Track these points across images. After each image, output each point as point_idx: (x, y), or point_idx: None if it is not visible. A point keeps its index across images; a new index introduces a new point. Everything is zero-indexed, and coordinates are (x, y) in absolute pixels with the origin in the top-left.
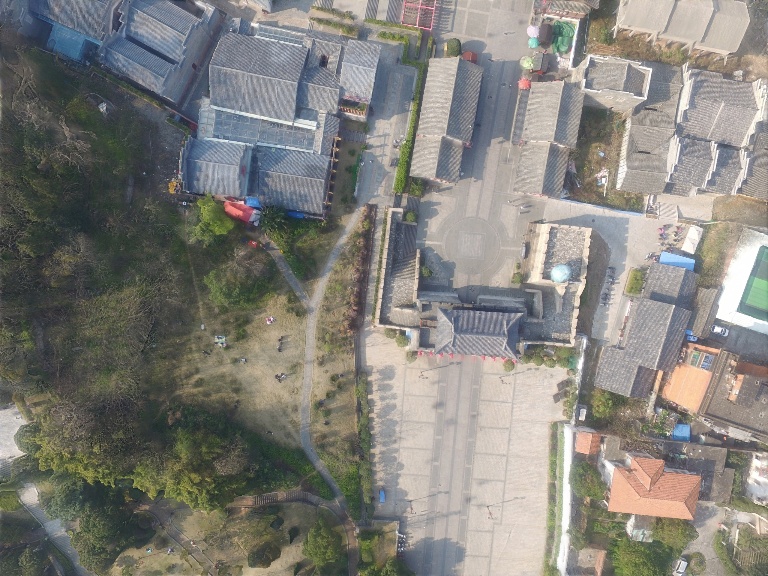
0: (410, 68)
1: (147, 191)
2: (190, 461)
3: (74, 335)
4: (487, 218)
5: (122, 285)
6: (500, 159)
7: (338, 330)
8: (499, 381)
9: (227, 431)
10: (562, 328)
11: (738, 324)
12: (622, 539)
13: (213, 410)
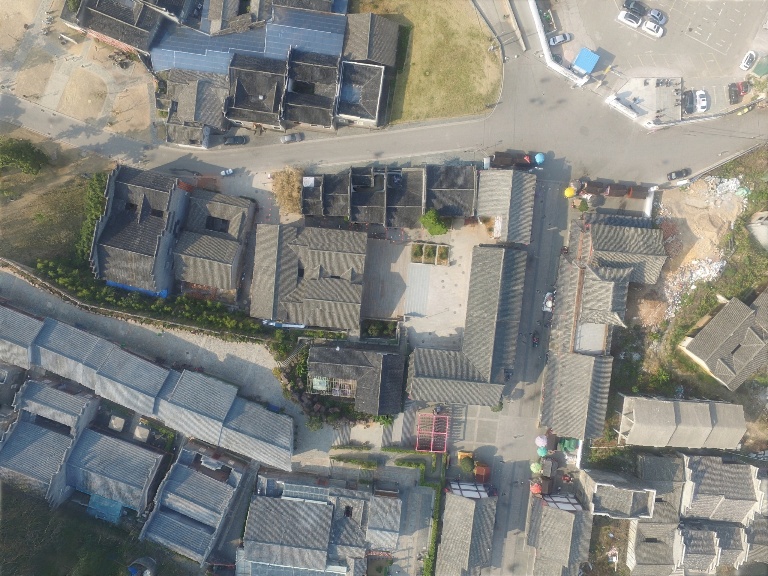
0: (428, 488)
1: None
2: None
3: None
4: None
5: None
6: (516, 548)
7: None
8: None
9: None
10: None
11: None
12: None
13: None
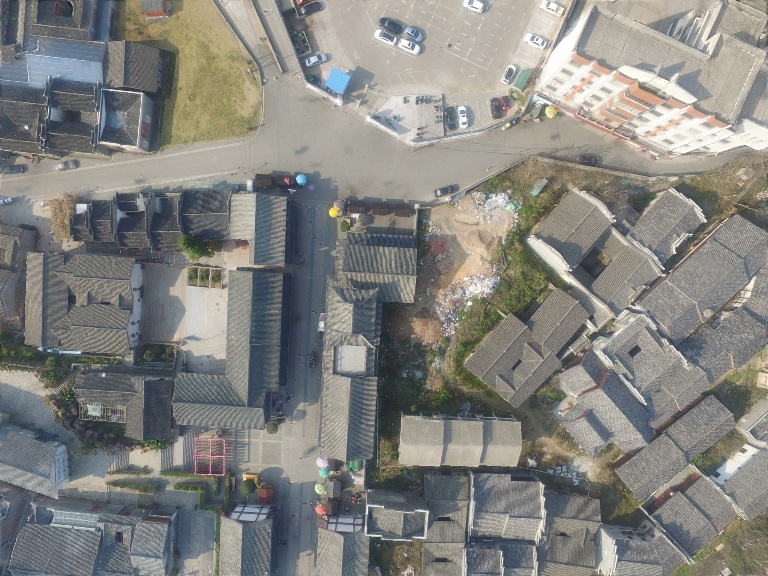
0: (209, 511)
1: None
2: None
3: None
4: None
5: None
6: (310, 569)
7: None
8: None
9: None
10: None
11: None
12: None
13: None
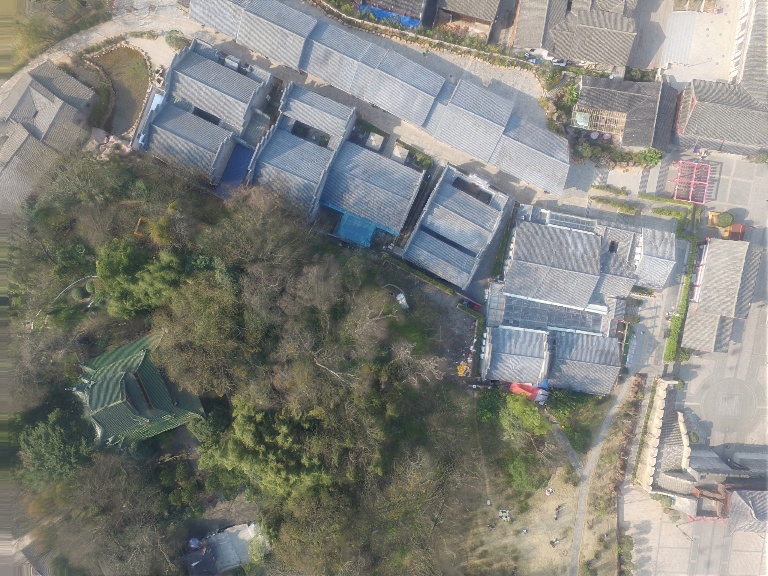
0: (682, 242)
1: None
2: None
3: (373, 519)
4: (745, 379)
5: None
6: (759, 322)
7: (605, 493)
8: (751, 532)
9: None
10: None
11: None
12: None
13: None
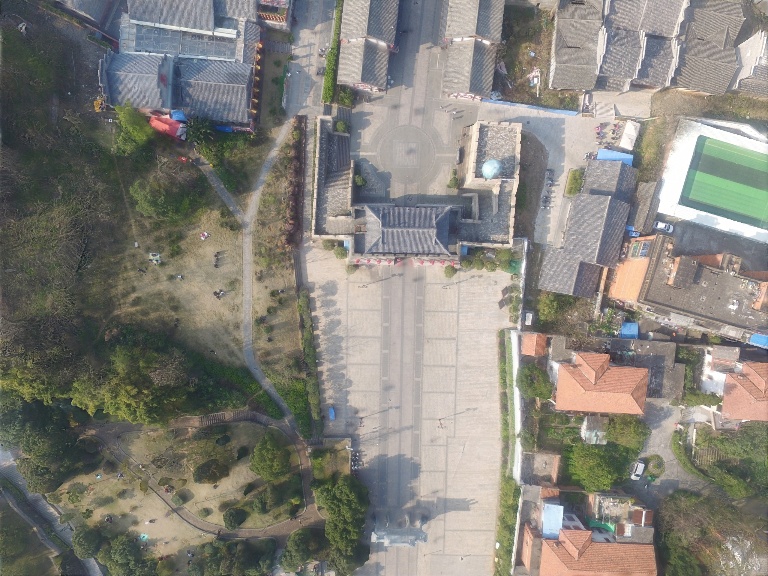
0: None
1: (73, 111)
2: (127, 375)
3: (6, 257)
4: (420, 125)
5: (52, 205)
6: (430, 65)
7: (276, 245)
8: (443, 291)
9: (168, 350)
10: (500, 229)
11: (681, 217)
12: (577, 444)
13: (152, 329)
